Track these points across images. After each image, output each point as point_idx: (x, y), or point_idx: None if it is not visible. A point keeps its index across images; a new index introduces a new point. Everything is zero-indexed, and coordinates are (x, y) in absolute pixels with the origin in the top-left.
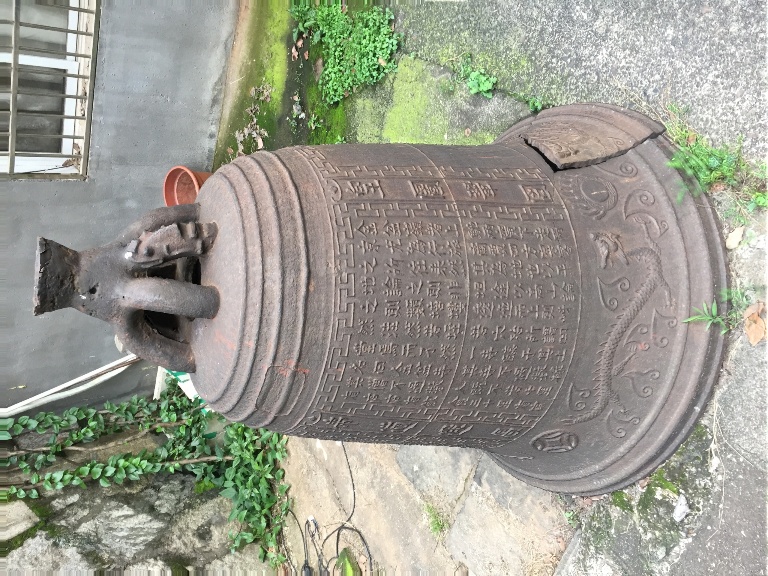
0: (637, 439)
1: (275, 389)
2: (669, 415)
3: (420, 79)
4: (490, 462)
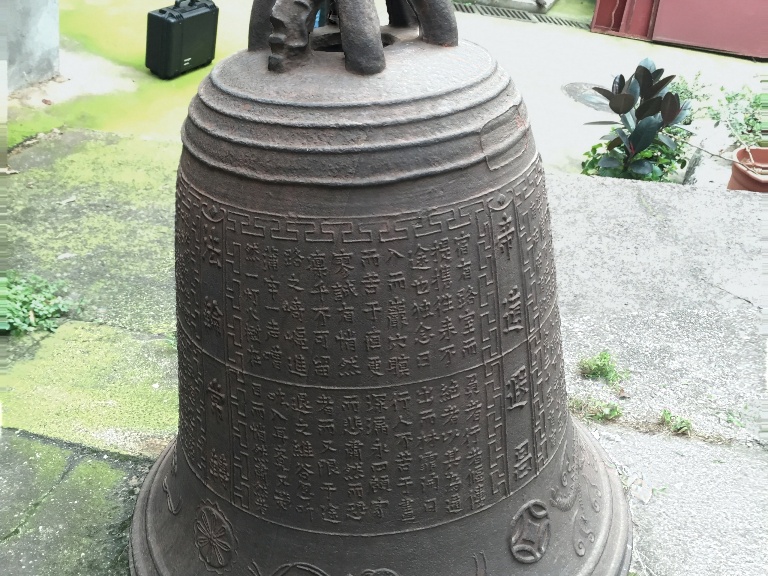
0: (595, 562)
1: (505, 130)
2: (615, 541)
3: (109, 340)
4: None
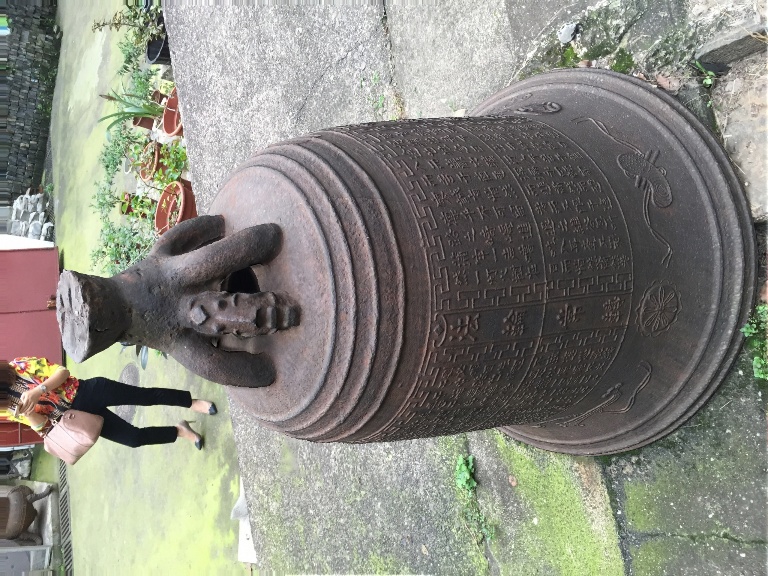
0: (530, 88)
1: None
2: None
3: None
4: (767, 196)
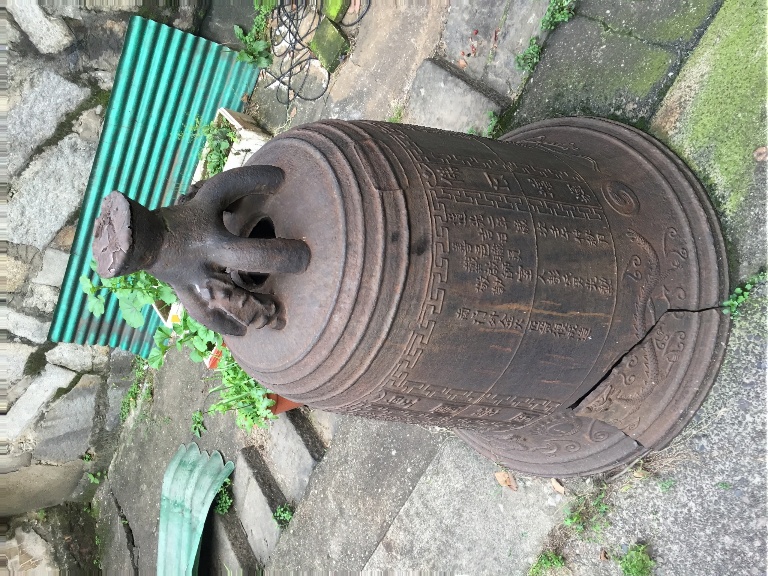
0: None
1: None
2: None
3: None
4: None
